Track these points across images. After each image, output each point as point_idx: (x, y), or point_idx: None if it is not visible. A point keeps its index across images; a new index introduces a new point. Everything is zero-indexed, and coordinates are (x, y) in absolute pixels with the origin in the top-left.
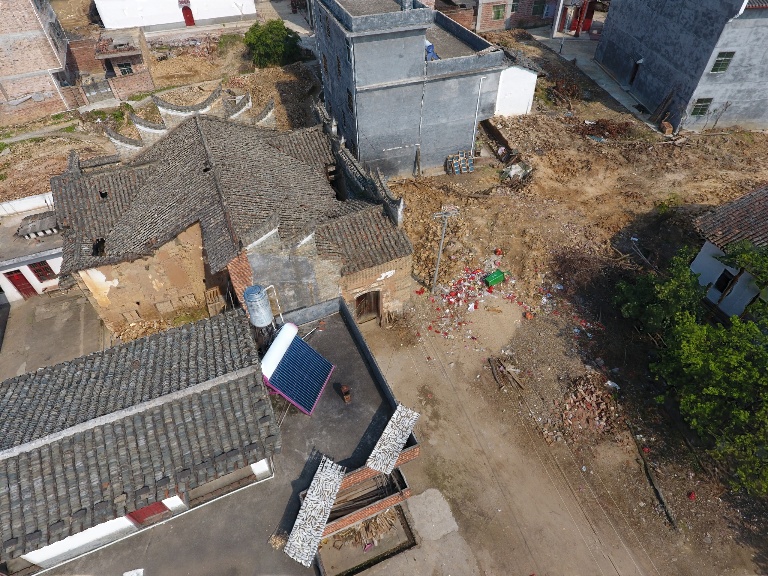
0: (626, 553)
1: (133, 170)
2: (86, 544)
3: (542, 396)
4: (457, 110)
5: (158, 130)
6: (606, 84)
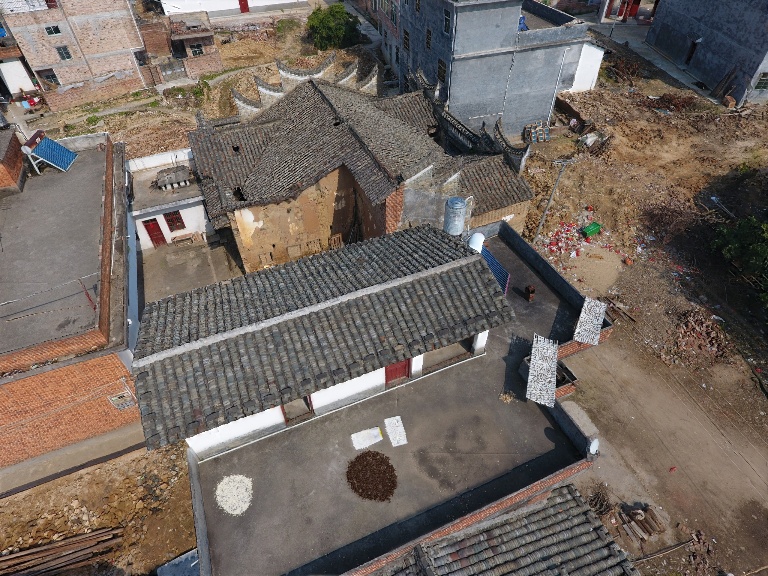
0: (755, 451)
1: (259, 127)
2: (350, 396)
3: (655, 327)
4: (540, 80)
5: (276, 93)
6: (662, 64)
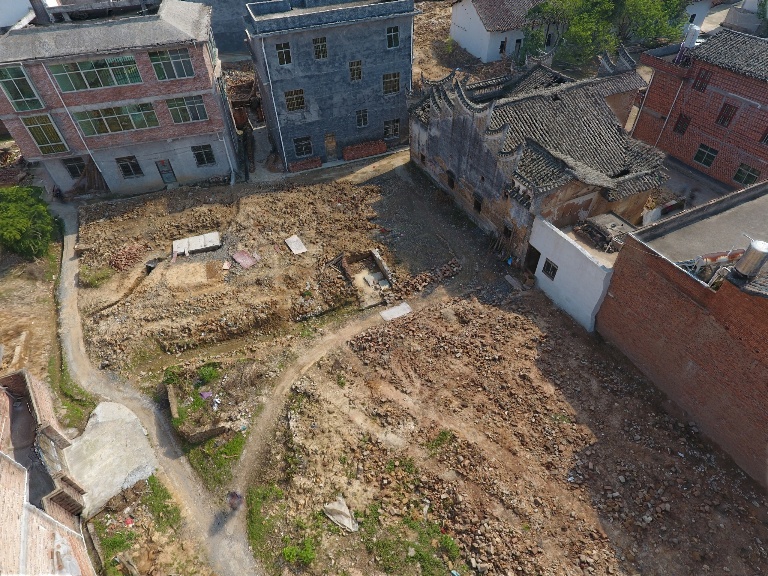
0: None
1: None
2: None
3: None
4: None
5: None
6: None
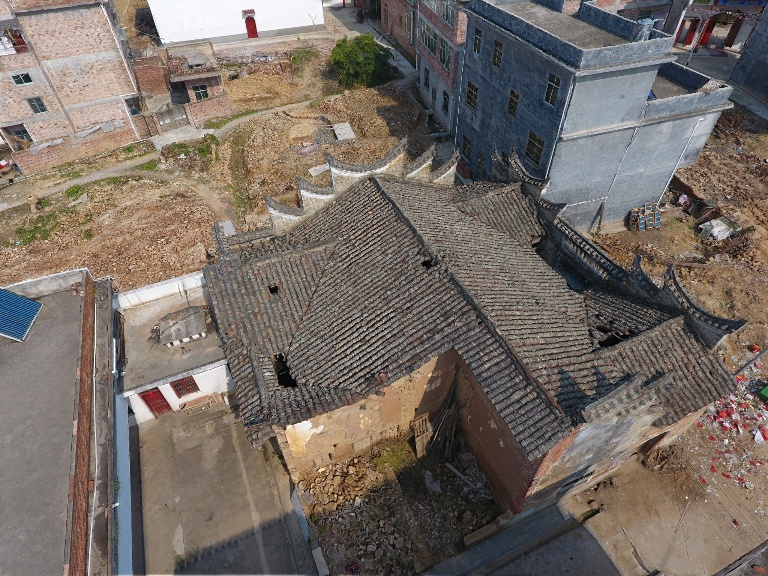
0: None
1: (305, 253)
2: None
3: None
4: (659, 157)
5: (324, 195)
6: (762, 111)
